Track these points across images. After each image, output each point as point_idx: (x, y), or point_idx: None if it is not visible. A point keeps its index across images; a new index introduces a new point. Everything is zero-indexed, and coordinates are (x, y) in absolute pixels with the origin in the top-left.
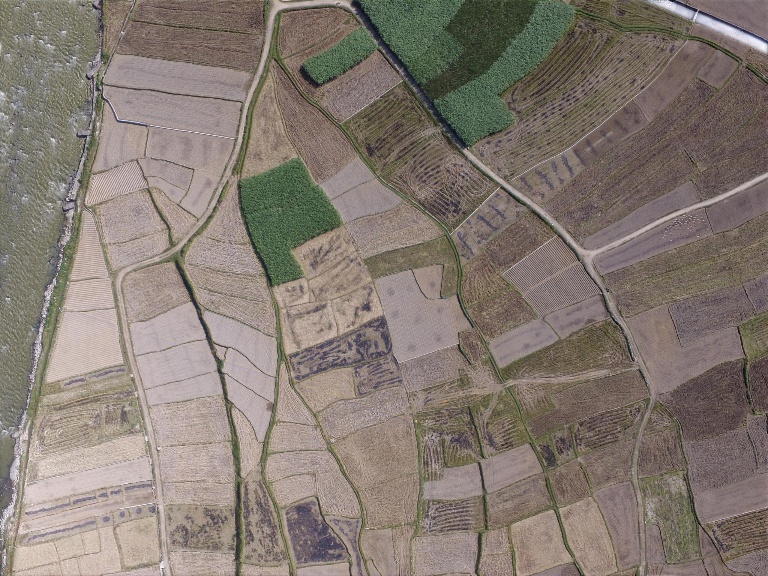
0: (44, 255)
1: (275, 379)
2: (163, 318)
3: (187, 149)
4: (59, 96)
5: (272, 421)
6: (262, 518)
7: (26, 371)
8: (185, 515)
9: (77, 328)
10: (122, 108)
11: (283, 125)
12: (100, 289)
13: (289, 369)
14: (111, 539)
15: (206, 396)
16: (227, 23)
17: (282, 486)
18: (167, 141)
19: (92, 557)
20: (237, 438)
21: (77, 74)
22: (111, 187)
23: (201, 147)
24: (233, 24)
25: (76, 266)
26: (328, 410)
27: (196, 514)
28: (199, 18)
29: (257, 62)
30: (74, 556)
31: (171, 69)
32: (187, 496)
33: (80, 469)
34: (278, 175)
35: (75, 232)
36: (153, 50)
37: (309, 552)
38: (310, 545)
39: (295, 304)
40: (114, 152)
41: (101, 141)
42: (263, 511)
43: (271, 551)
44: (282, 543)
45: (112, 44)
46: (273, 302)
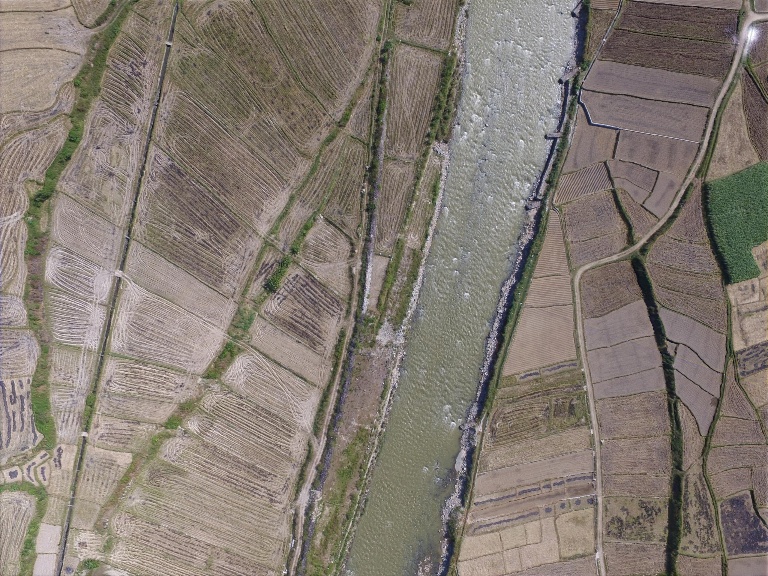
0: (504, 252)
1: (721, 375)
2: (615, 314)
3: (654, 152)
4: (532, 99)
5: (716, 416)
6: (700, 510)
7: (478, 364)
8: (621, 507)
9: (535, 323)
10: (596, 112)
11: (747, 130)
12: (560, 286)
13: (736, 365)
14: (551, 530)
15: (649, 391)
16: (703, 32)
17: (720, 479)
18: (636, 144)
19: (532, 547)
20: (681, 432)
21: (550, 79)
22: (577, 187)
23: (667, 150)
24: (708, 33)
25: (539, 263)
26: (767, 405)
27: (632, 506)
28: (677, 27)
29: (727, 70)
30: (516, 546)
31: (646, 75)
32: (625, 488)
33: (527, 461)
34: (747, 178)
35: (542, 230)
36: (632, 57)
37: (740, 544)
38: (741, 537)
39: (746, 302)
40: (584, 154)
41: (573, 143)
42: (701, 503)
43: (706, 543)
44: (717, 535)
45: (594, 51)
46: (726, 300)
